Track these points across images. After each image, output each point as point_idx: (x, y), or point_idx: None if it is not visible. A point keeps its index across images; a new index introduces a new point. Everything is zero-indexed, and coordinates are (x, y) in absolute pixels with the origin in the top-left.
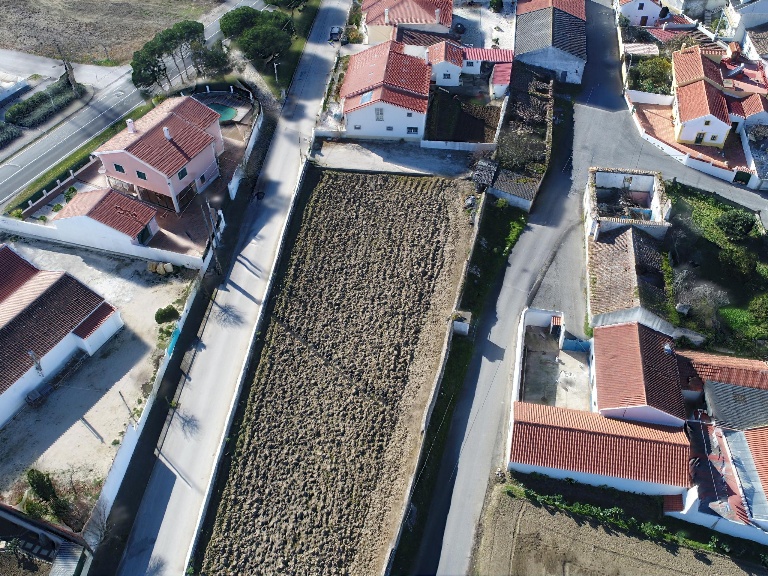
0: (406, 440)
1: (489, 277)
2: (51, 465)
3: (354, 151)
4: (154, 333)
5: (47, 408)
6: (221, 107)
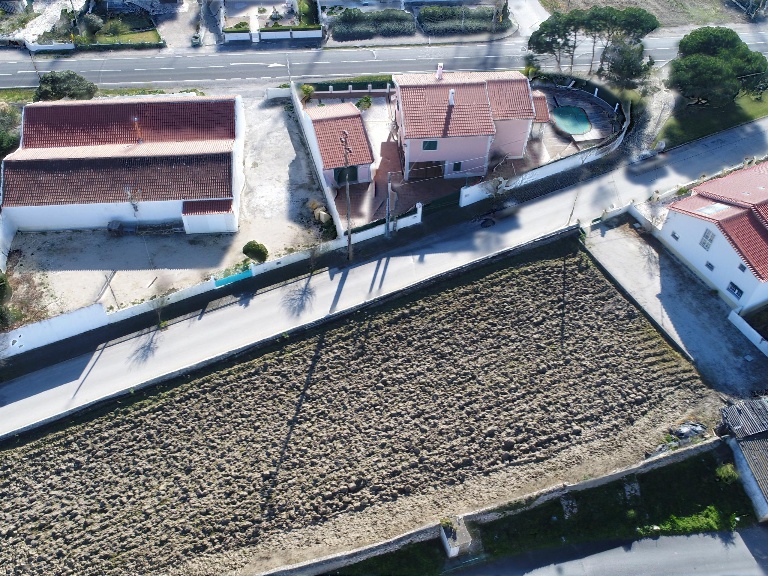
0: (230, 571)
1: (578, 531)
2: (56, 283)
3: (642, 258)
4: (240, 258)
5: (115, 242)
6: (582, 116)
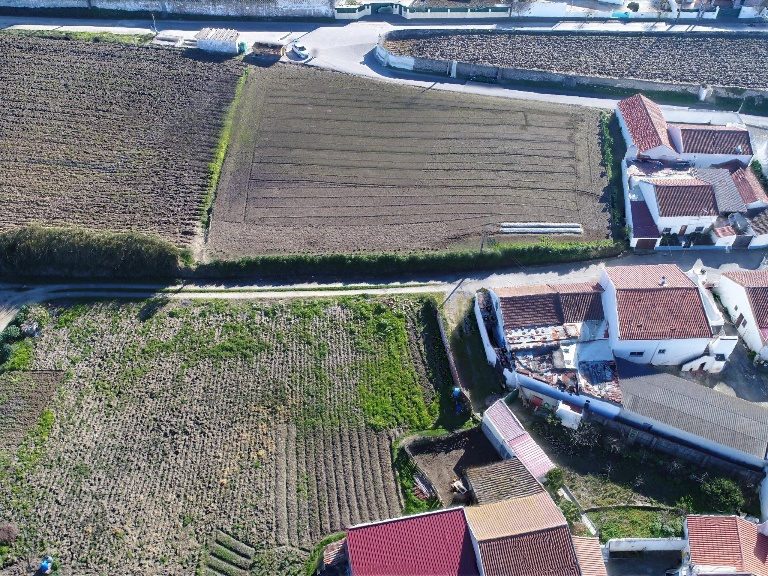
0: None
1: (760, 110)
2: None
3: None
4: None
5: None
6: None
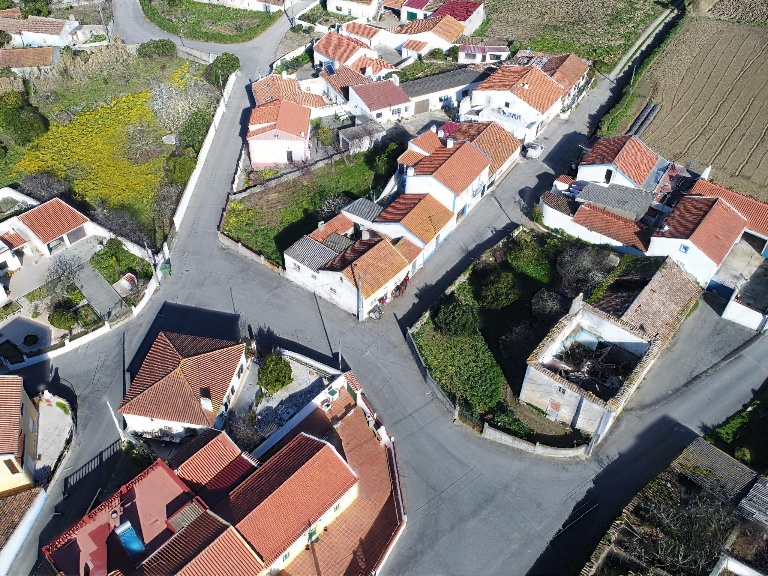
0: None
1: None
2: None
3: None
4: None
5: None
6: None
